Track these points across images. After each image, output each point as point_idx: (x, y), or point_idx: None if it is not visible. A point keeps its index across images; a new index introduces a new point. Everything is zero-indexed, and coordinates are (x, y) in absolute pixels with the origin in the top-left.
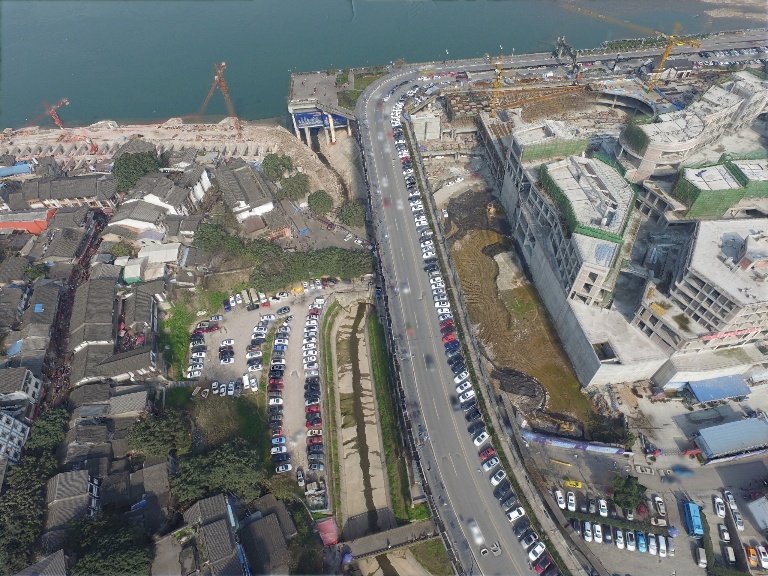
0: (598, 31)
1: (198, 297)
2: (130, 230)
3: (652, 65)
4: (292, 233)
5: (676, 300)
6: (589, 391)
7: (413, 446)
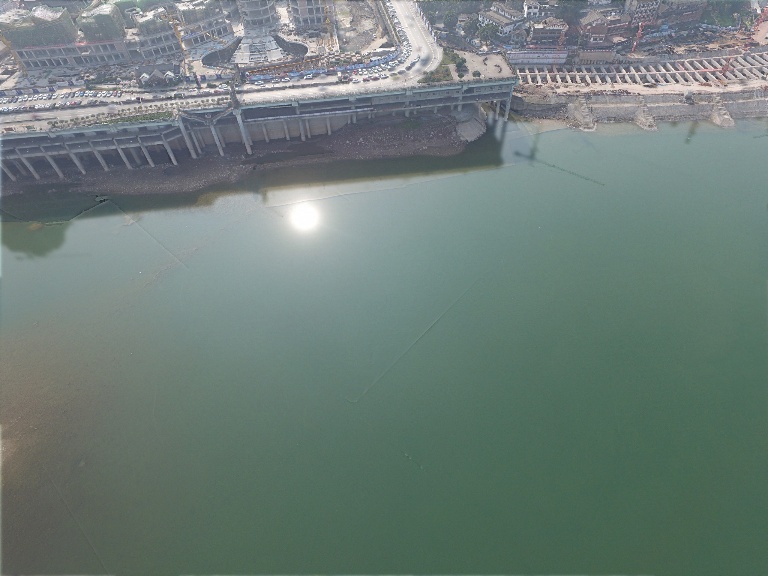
0: (67, 295)
1: None
2: None
3: (175, 65)
4: None
5: None
6: None
7: None
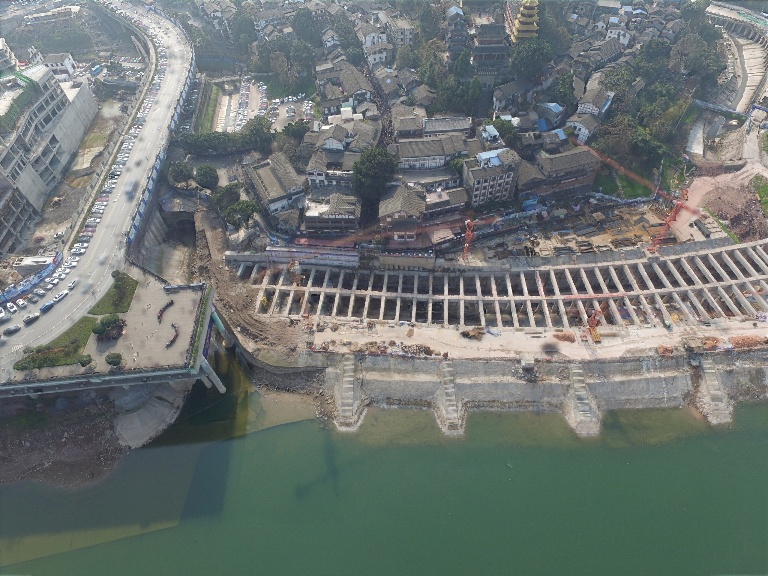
0: None
1: None
2: None
3: None
4: (244, 178)
5: None
6: None
7: None
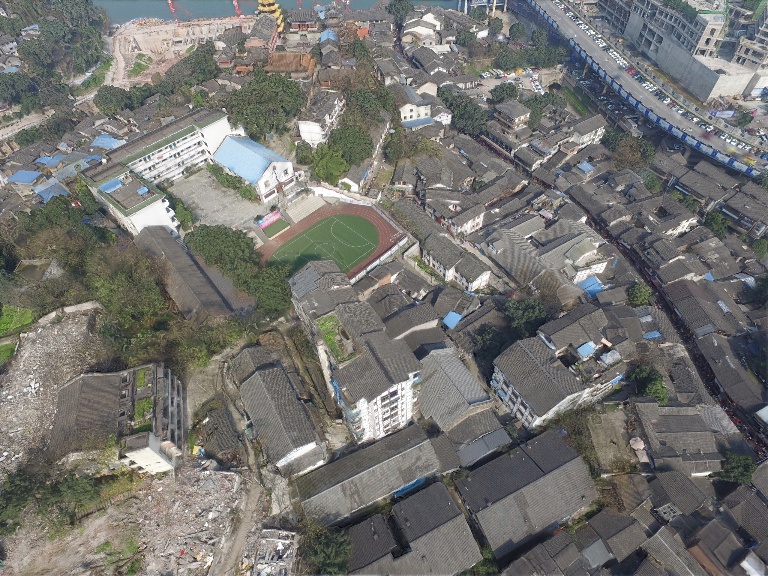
0: None
1: (467, 70)
2: (417, 36)
3: None
4: None
5: (758, 41)
6: (708, 102)
7: (636, 99)
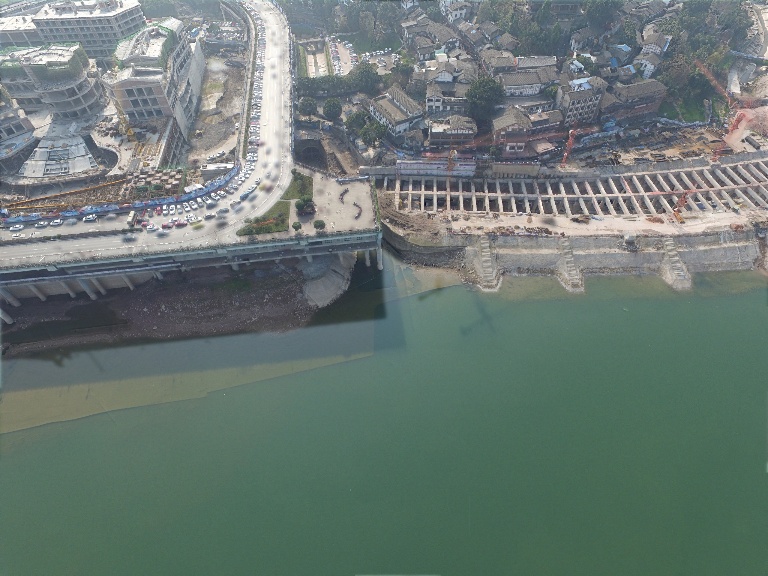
0: None
1: None
2: None
3: None
4: None
5: None
6: None
7: None
